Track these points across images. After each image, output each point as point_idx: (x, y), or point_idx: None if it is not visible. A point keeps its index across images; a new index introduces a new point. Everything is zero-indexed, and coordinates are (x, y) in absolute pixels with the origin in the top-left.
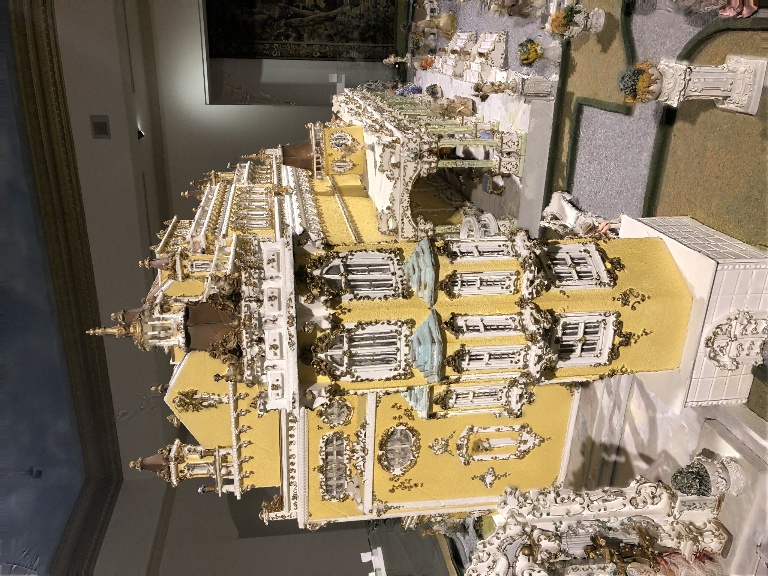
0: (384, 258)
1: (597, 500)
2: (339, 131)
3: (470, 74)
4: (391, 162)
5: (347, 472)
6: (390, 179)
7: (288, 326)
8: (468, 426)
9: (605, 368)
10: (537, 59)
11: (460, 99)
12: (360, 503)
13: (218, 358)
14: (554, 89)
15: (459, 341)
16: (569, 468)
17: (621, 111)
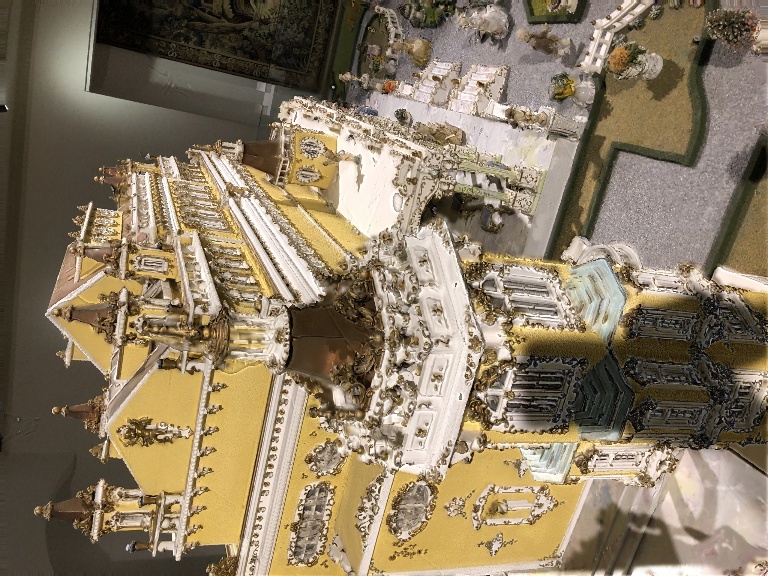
0: (543, 278)
1: (614, 574)
2: (312, 137)
3: (458, 103)
4: (407, 176)
5: (324, 531)
6: (402, 195)
7: (470, 352)
8: (491, 485)
9: (743, 435)
10: (569, 96)
11: (450, 126)
12: (352, 572)
13: (340, 386)
14: (579, 130)
15: (645, 391)
16: (574, 535)
17: (680, 161)
